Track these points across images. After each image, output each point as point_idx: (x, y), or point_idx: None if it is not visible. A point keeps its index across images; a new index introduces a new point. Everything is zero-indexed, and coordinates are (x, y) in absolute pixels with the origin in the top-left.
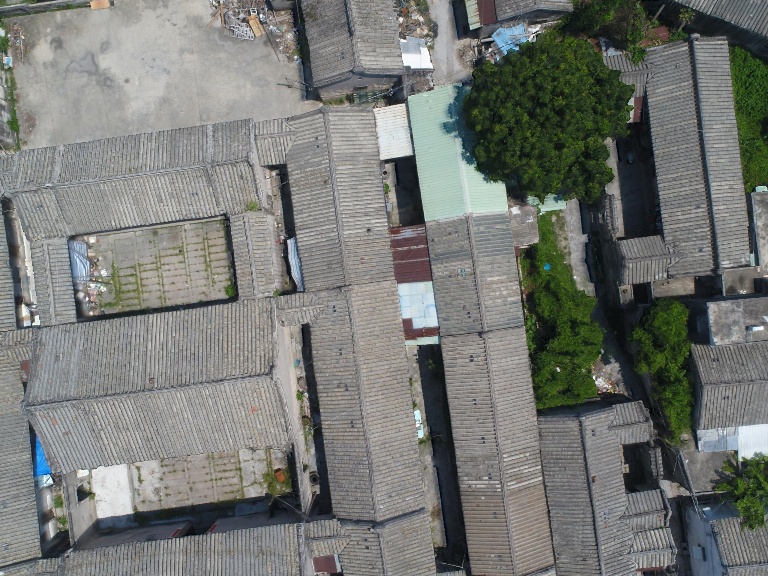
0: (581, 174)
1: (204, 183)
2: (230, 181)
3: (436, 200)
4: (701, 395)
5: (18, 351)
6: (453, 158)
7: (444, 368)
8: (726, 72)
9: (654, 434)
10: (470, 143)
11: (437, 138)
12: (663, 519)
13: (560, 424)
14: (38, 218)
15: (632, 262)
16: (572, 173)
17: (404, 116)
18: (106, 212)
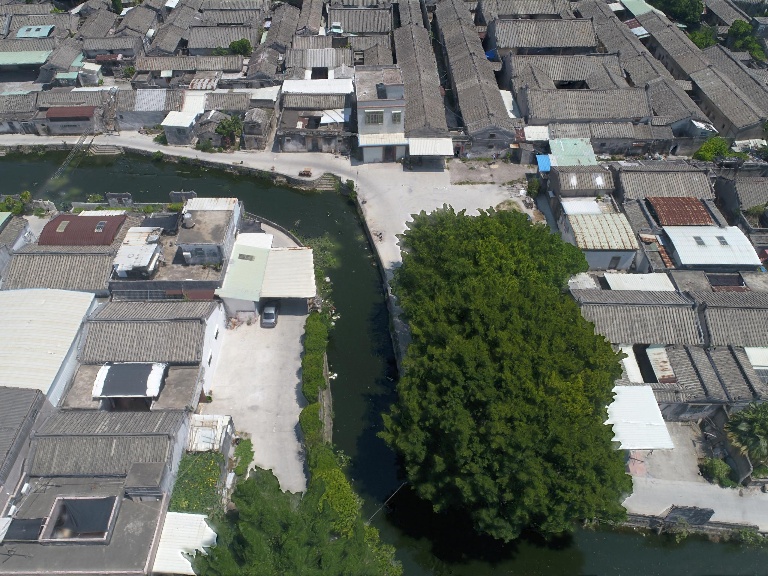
0: (691, 6)
1: (551, 4)
2: (560, 4)
3: (638, 11)
4: (764, 42)
5: (479, 29)
6: (642, 3)
7: (655, 37)
8: (734, 4)
9: (751, 57)
10: (647, 2)
11: (634, 2)
12: (767, 73)
13: (709, 49)
14: (488, 8)
15: (720, 27)
16: (688, 4)
17: (619, 4)
18: (513, 9)
